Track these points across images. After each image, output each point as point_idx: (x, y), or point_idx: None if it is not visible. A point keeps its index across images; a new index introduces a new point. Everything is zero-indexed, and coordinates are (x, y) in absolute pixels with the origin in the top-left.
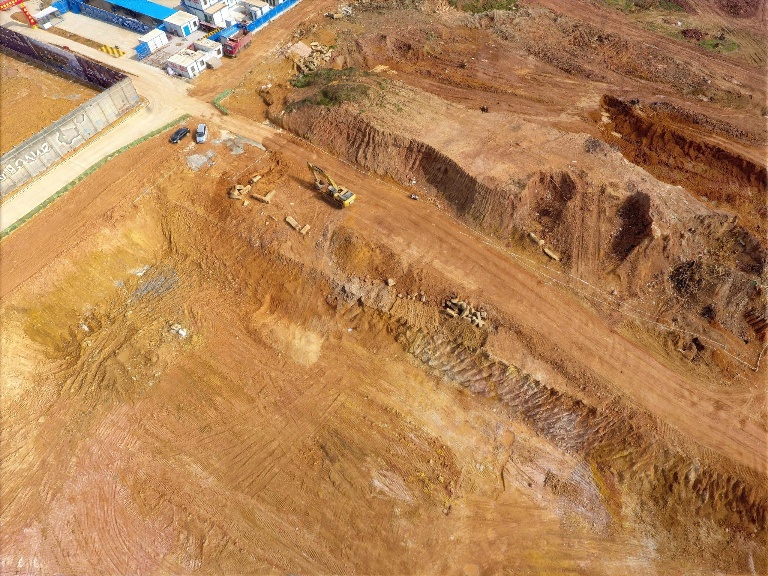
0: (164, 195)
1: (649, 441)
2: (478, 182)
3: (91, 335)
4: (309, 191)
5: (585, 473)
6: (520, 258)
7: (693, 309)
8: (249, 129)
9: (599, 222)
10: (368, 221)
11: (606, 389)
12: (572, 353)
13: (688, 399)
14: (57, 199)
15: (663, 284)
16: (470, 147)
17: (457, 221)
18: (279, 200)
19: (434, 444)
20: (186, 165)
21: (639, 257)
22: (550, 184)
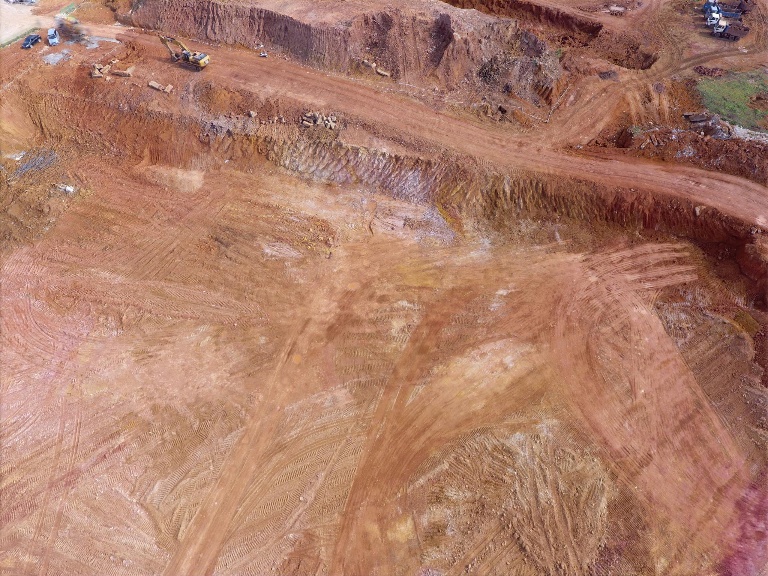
0: (26, 86)
1: (472, 172)
2: (312, 27)
3: None
4: (167, 64)
5: (434, 212)
6: (359, 80)
7: (496, 89)
8: (101, 30)
9: (415, 42)
10: (225, 76)
11: (436, 147)
12: (408, 130)
13: (499, 144)
14: None
15: (473, 79)
16: (302, 6)
17: (303, 66)
18: (140, 73)
19: (312, 219)
20: (43, 62)
21: (449, 60)
22: (374, 25)
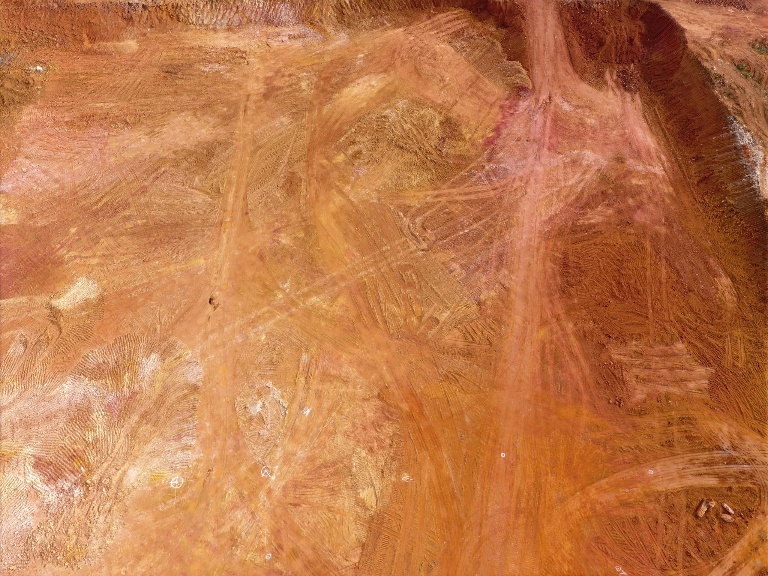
0: None
1: None
2: None
3: None
4: None
5: (306, 28)
6: None
7: None
8: None
9: None
10: None
11: None
12: None
13: None
14: None
15: None
16: None
17: None
18: None
19: (227, 48)
20: None
21: None
22: None
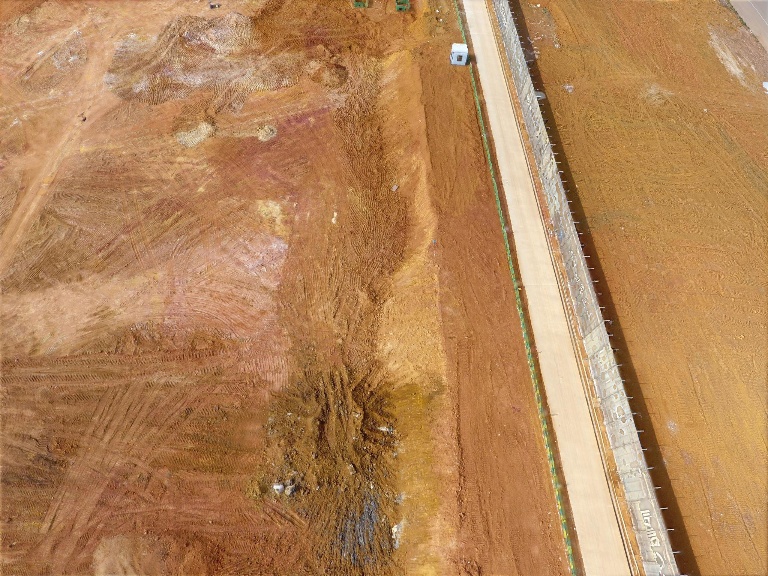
0: None
1: None
2: None
3: (362, 423)
4: None
5: None
6: None
7: None
8: None
9: None
10: None
11: None
12: None
13: None
14: (567, 548)
15: None
16: None
17: None
18: None
19: None
20: None
21: None
22: None
